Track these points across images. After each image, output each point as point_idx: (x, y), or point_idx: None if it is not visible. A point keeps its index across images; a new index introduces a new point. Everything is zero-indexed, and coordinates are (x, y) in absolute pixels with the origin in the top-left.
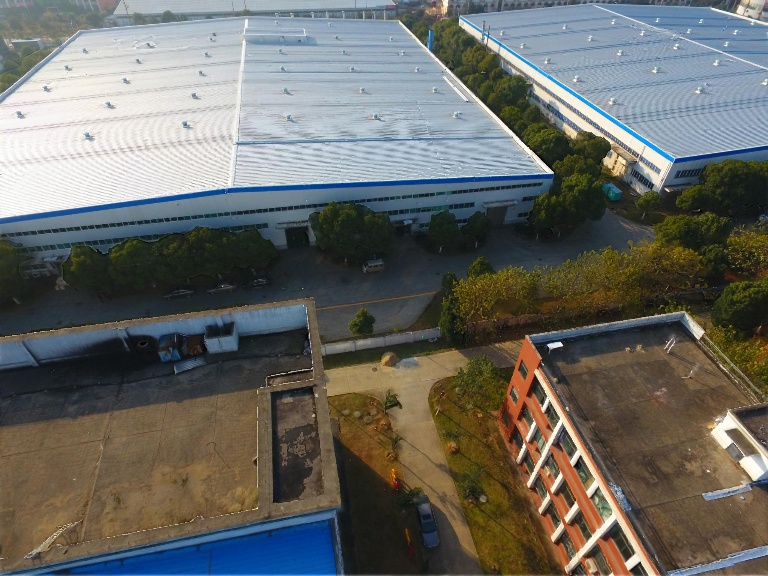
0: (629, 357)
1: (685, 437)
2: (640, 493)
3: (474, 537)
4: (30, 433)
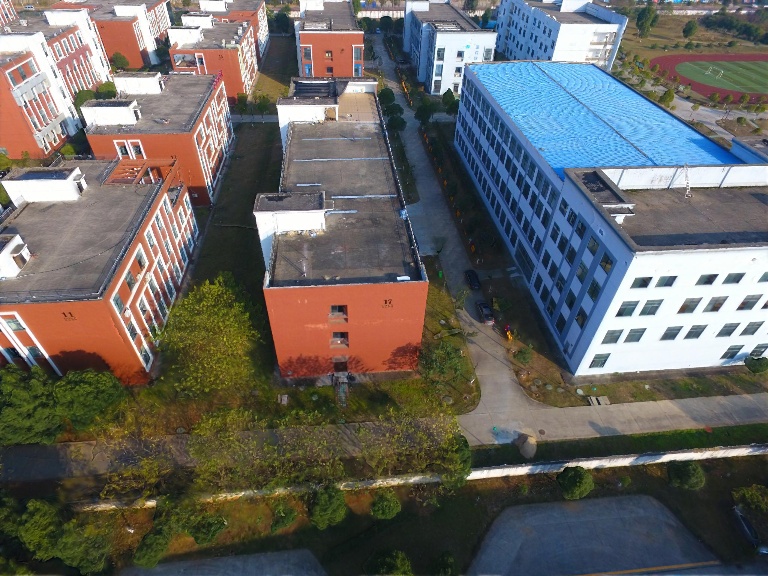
0: (342, 273)
1: (344, 231)
2: (391, 215)
3: (453, 305)
4: (762, 227)
